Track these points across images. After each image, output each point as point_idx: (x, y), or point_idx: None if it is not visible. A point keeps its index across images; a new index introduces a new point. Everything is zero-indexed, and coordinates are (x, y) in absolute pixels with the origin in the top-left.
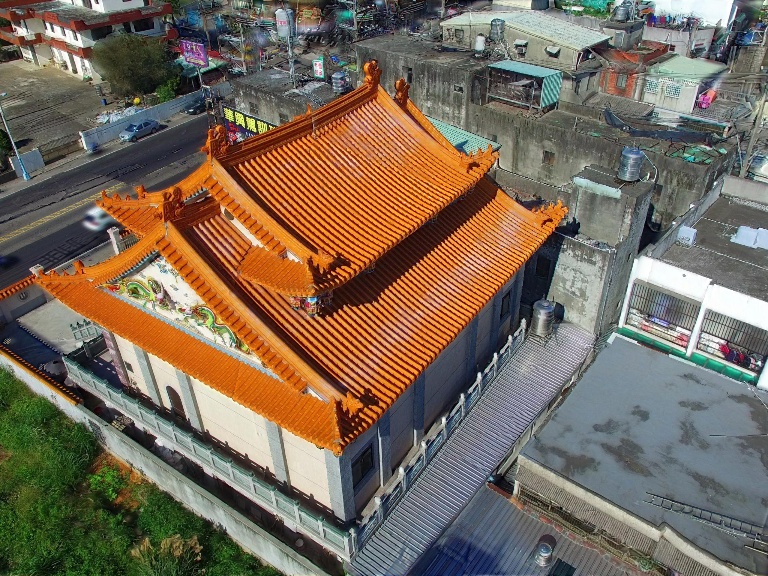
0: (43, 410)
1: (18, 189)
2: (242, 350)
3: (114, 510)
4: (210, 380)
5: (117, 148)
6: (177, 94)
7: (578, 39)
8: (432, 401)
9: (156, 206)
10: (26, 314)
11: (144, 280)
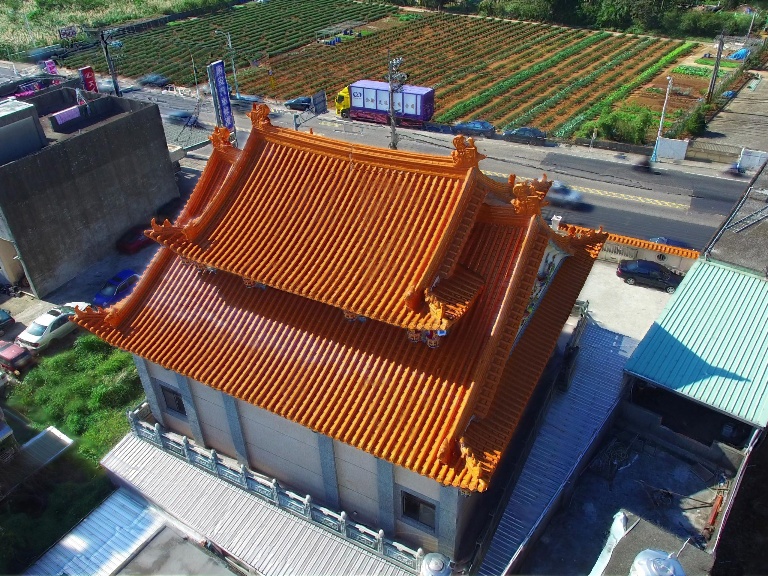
0: None
1: (633, 163)
2: None
3: None
4: None
5: None
6: None
7: None
8: None
9: None
10: None
11: None
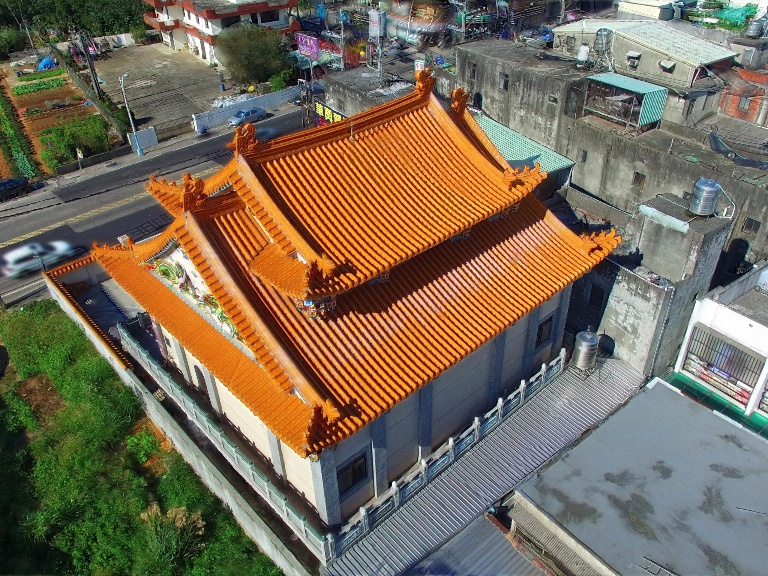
0: (100, 369)
1: (131, 163)
2: (244, 342)
3: (141, 472)
4: (212, 367)
5: (224, 132)
6: (289, 85)
7: (698, 54)
8: (444, 420)
9: None
10: (110, 279)
11: (173, 263)
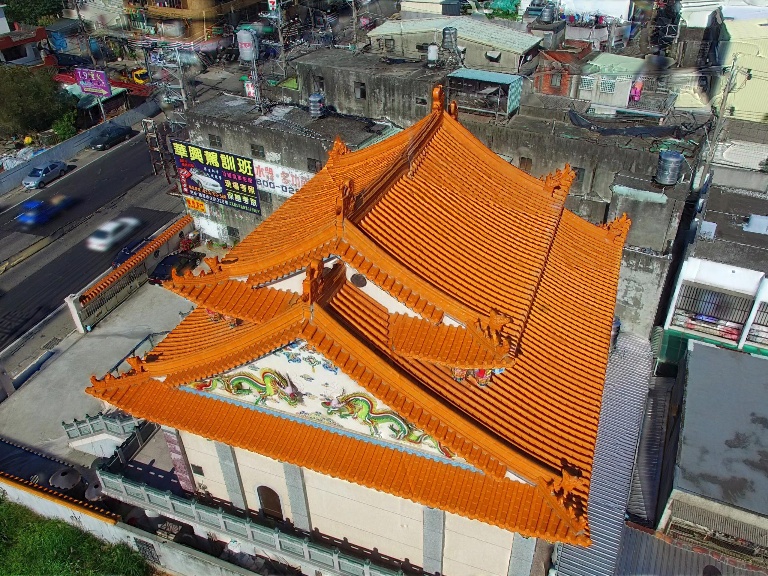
0: (65, 537)
1: None
2: (409, 440)
3: None
4: (375, 482)
5: (23, 198)
6: None
7: (515, 42)
8: None
9: (238, 279)
10: None
11: (255, 372)
